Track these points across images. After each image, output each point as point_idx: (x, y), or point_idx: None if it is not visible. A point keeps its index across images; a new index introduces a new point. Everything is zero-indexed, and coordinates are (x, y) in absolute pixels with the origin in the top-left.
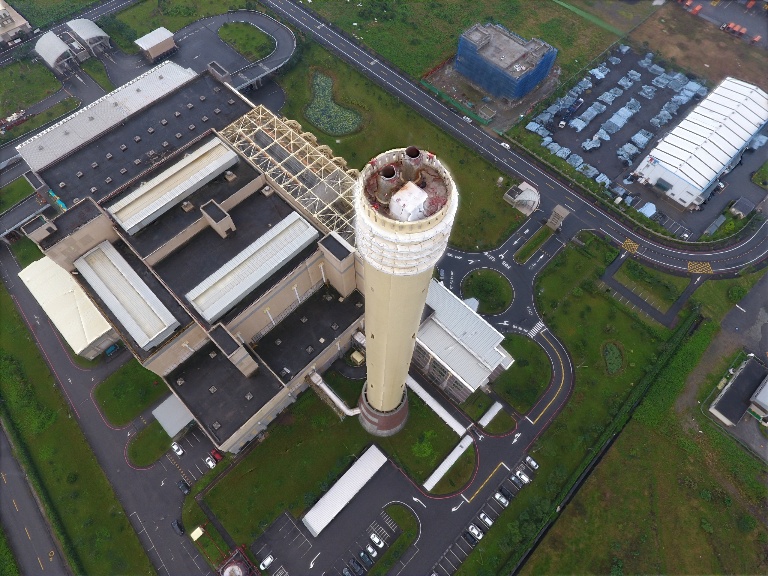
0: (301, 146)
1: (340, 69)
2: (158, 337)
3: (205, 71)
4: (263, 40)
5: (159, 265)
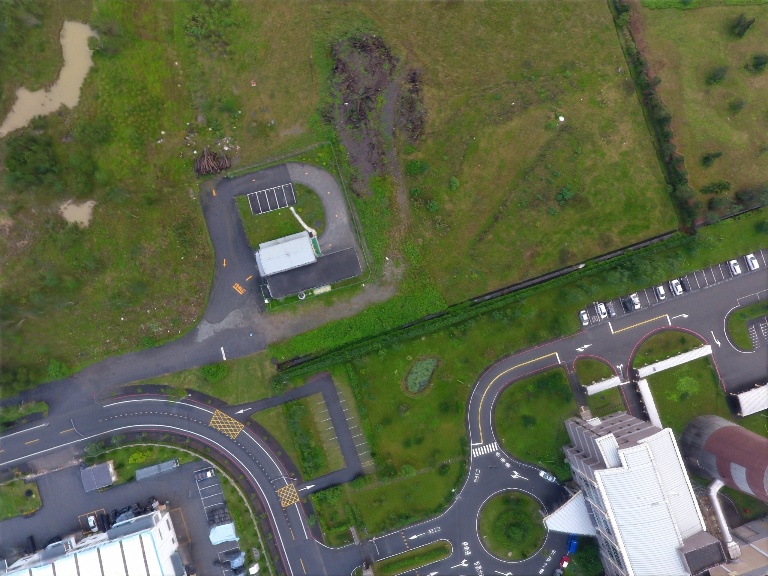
0: None
1: None
2: None
3: None
4: None
5: None
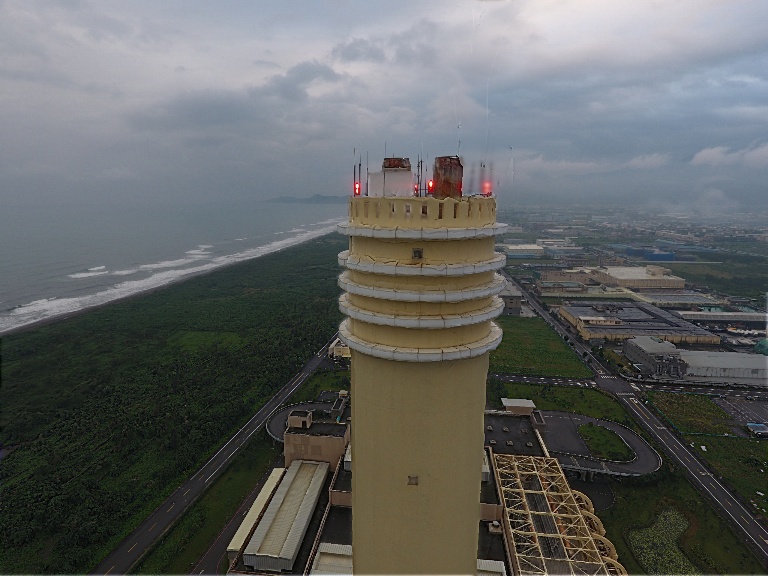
0: (575, 520)
1: (709, 520)
2: (264, 559)
3: (526, 416)
4: (622, 451)
5: (338, 509)
